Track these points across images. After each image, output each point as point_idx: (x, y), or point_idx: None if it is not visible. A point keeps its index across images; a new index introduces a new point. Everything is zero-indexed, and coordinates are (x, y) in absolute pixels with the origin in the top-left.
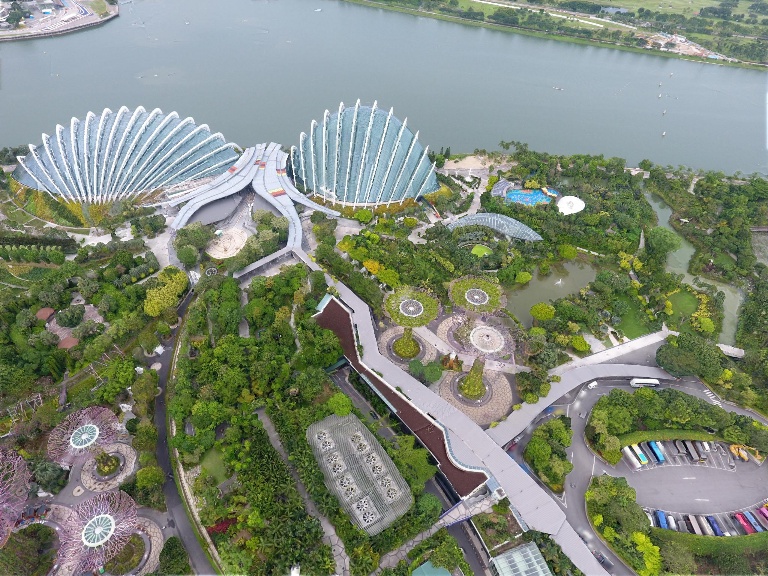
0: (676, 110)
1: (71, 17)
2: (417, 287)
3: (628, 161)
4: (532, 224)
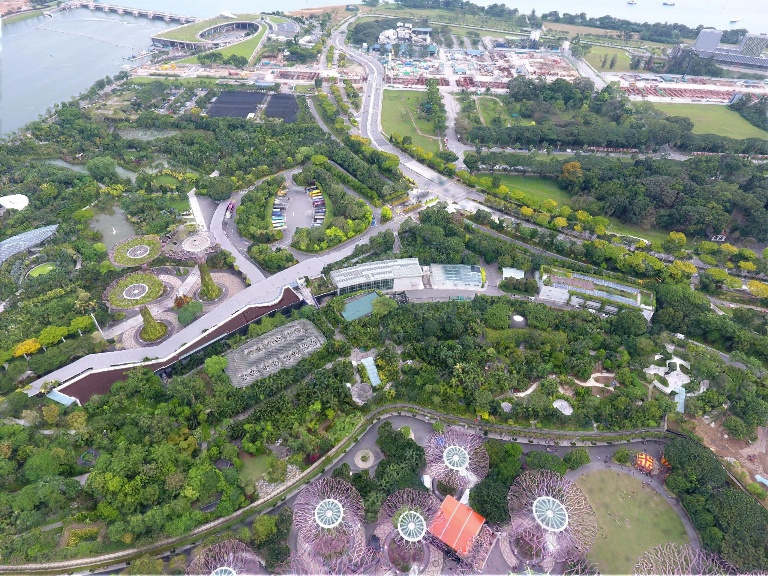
0: None
1: None
2: (110, 285)
3: None
4: (25, 230)
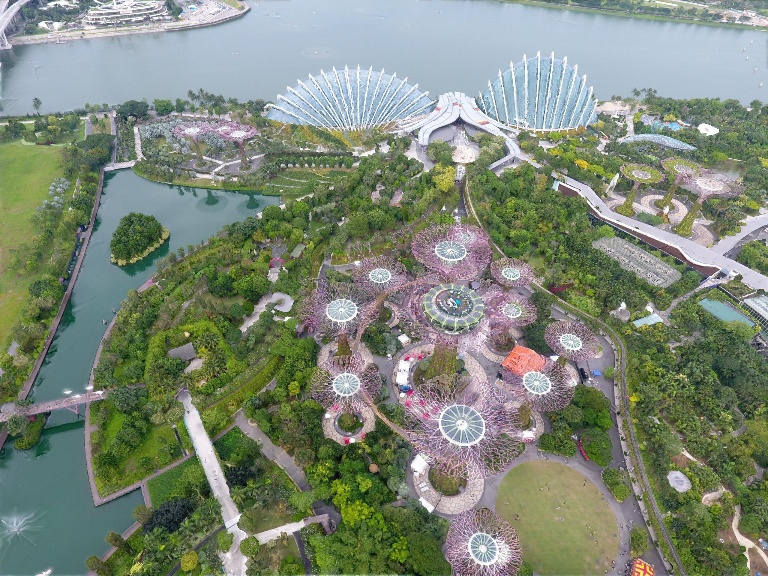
0: (765, 68)
1: (216, 11)
2: (639, 164)
3: None
4: None
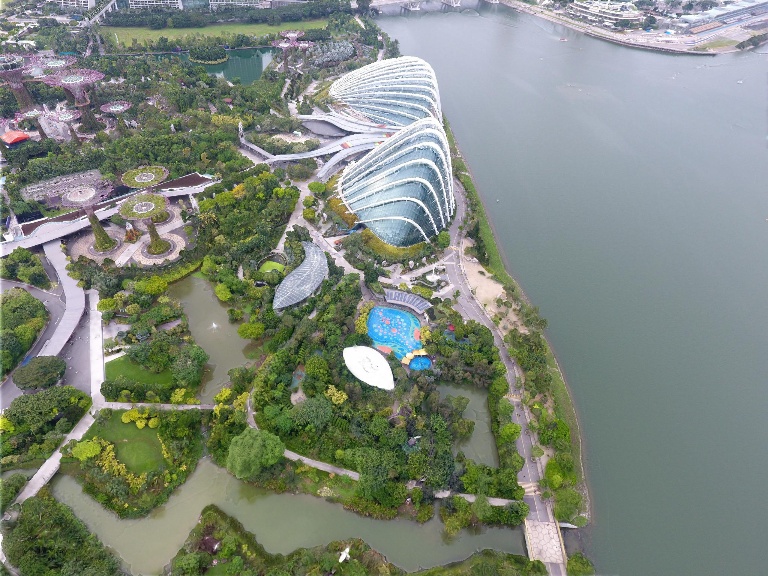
0: None
1: (669, 40)
2: None
3: (610, 552)
4: (318, 313)
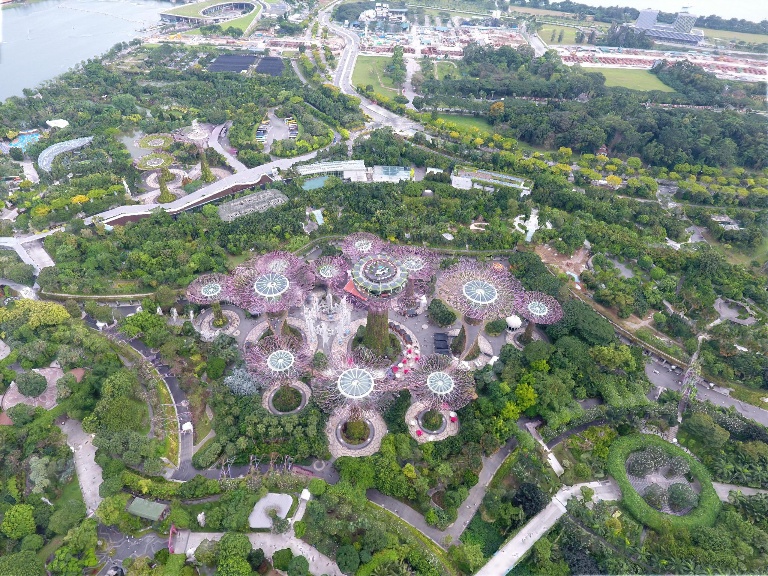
0: None
1: None
2: None
3: None
4: None
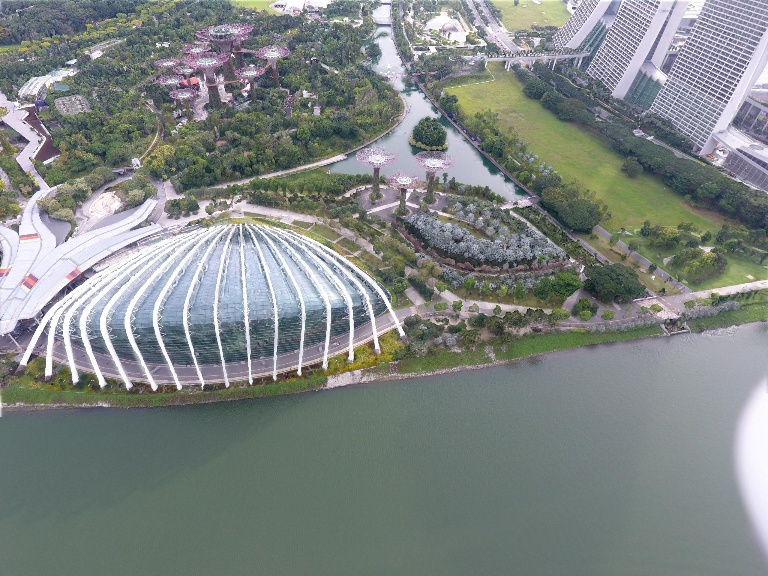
0: None
1: None
2: None
3: None
4: None
